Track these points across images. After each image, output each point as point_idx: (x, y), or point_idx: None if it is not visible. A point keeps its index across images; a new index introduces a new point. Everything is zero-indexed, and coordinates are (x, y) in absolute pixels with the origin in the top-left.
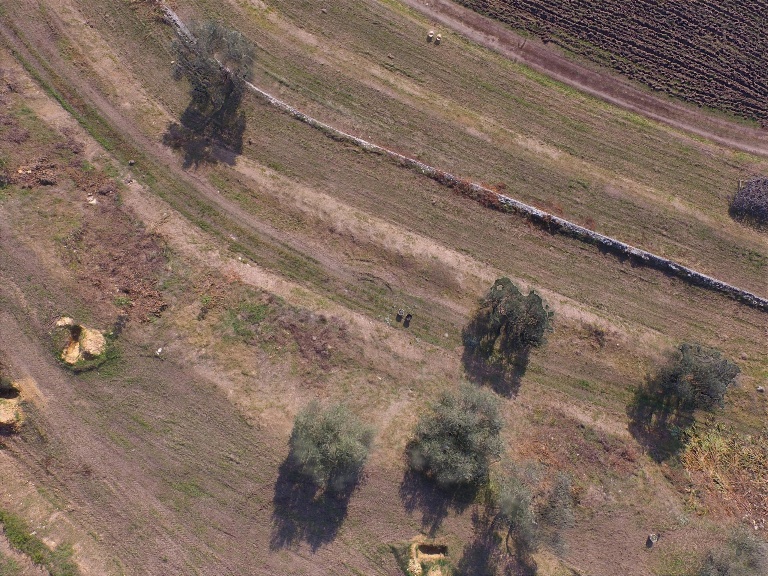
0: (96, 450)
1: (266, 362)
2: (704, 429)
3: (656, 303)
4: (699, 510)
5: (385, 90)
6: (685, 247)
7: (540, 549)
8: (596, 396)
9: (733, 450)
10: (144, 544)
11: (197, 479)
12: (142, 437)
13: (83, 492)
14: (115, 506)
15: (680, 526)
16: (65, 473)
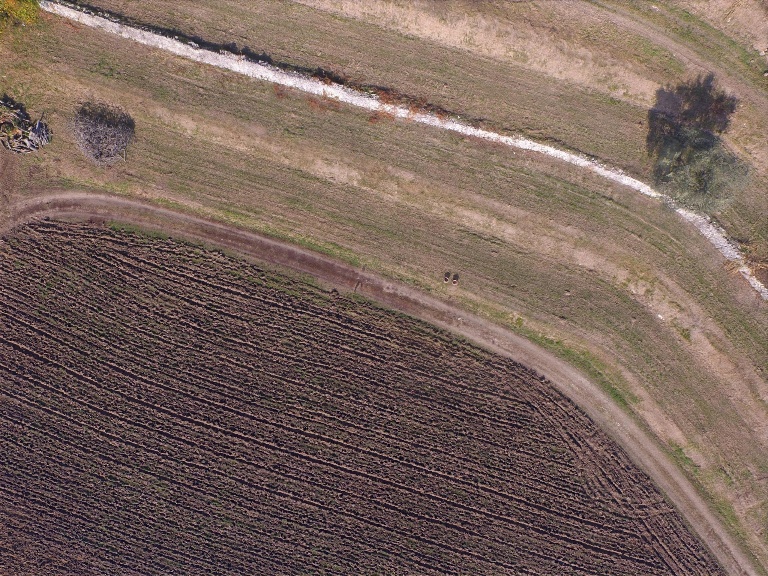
0: None
1: None
2: None
3: (208, 7)
4: None
5: (502, 207)
6: (179, 77)
7: None
8: None
9: None
10: None
11: None
12: None
13: None
14: None
15: None
16: None
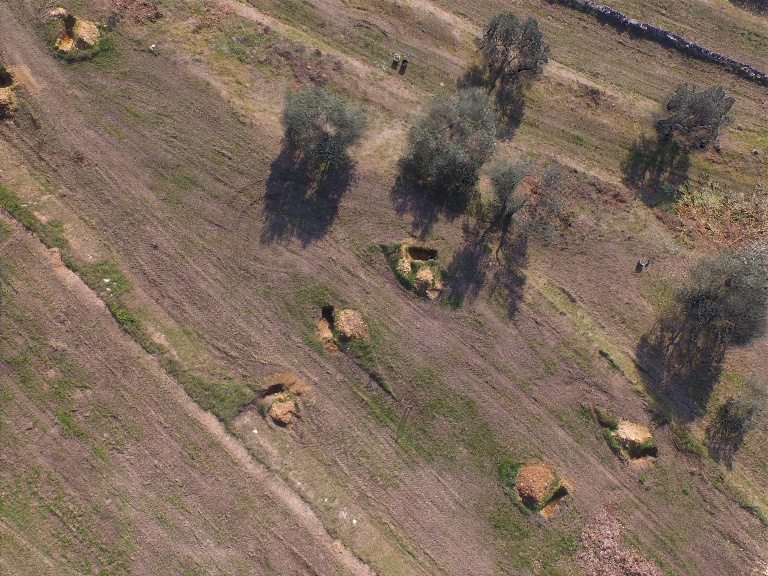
0: (88, 138)
1: (260, 79)
2: (697, 187)
3: (653, 74)
4: (690, 245)
5: None
6: (684, 26)
7: (530, 267)
8: (590, 151)
9: (726, 207)
10: (135, 231)
11: (189, 172)
12: (135, 128)
13: (75, 178)
14: (107, 193)
15: (670, 255)
16: (57, 159)
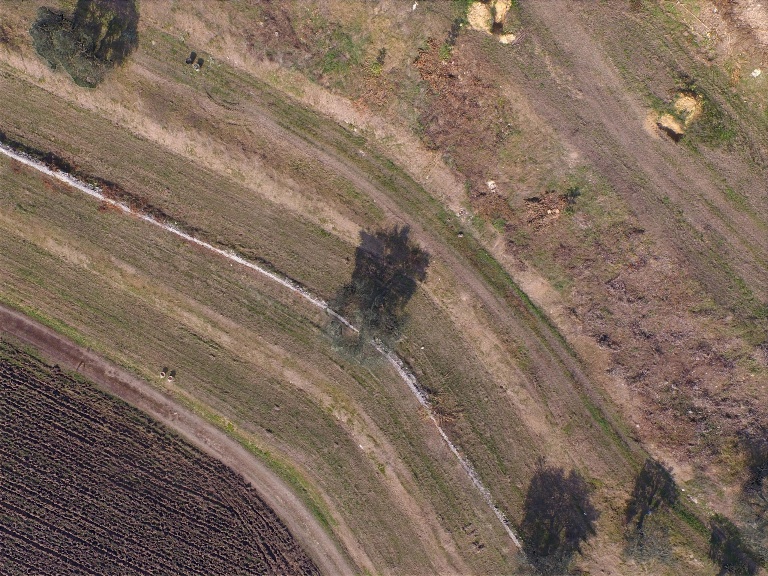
0: None
1: (320, 4)
2: None
3: None
4: None
5: (215, 316)
6: None
7: None
8: None
9: None
10: None
11: None
12: None
13: None
14: None
15: None
16: None
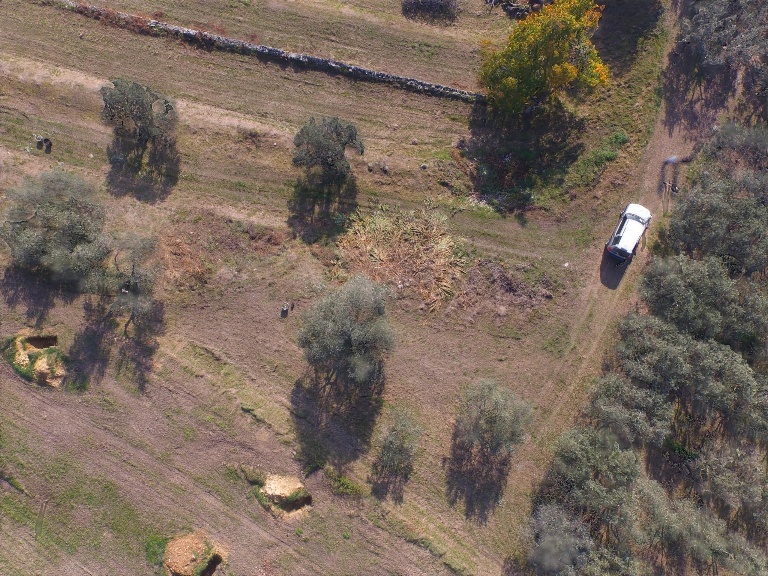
0: None
1: None
2: (369, 212)
3: (323, 104)
4: (341, 278)
5: None
6: (355, 49)
7: (168, 333)
8: (255, 196)
9: (397, 227)
10: None
11: None
12: None
13: None
14: None
15: (316, 293)
16: None
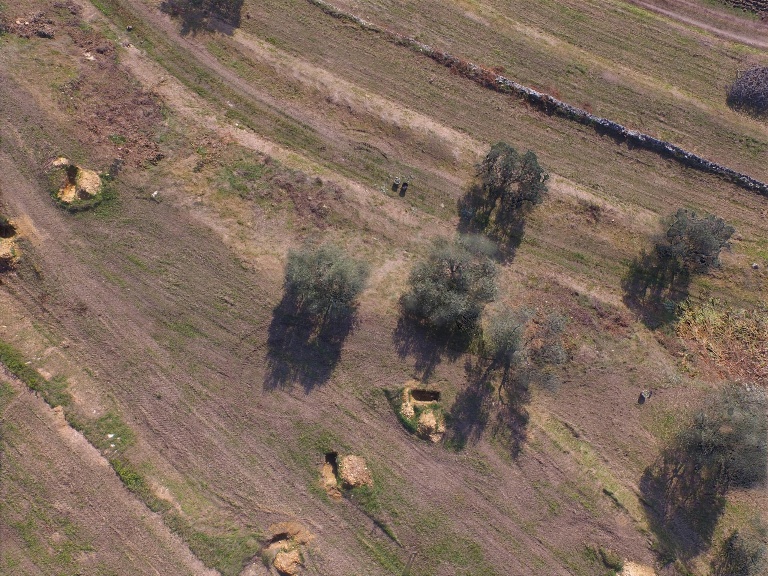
0: (91, 288)
1: (262, 216)
2: (698, 303)
3: (652, 185)
4: (692, 372)
5: None
6: (682, 133)
7: (532, 402)
8: (591, 269)
9: (727, 323)
10: (138, 381)
11: (192, 319)
12: (137, 277)
13: (78, 329)
14: (110, 343)
15: (672, 385)
16: (60, 310)
